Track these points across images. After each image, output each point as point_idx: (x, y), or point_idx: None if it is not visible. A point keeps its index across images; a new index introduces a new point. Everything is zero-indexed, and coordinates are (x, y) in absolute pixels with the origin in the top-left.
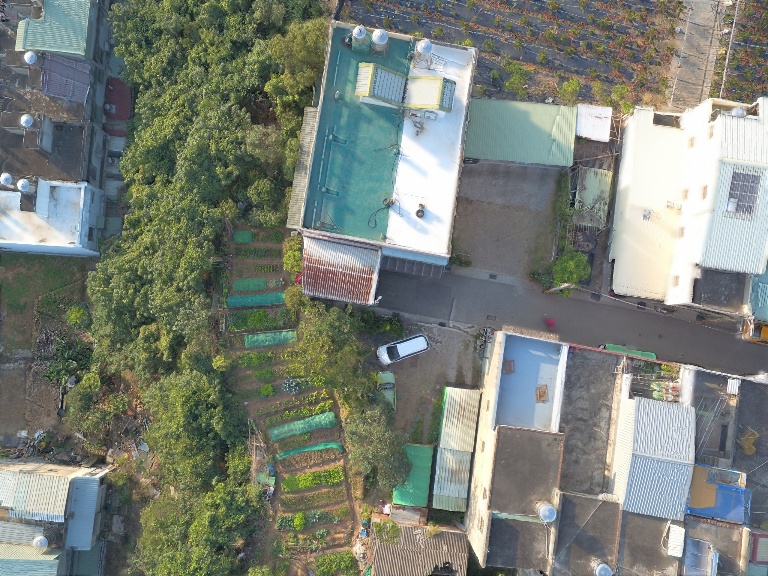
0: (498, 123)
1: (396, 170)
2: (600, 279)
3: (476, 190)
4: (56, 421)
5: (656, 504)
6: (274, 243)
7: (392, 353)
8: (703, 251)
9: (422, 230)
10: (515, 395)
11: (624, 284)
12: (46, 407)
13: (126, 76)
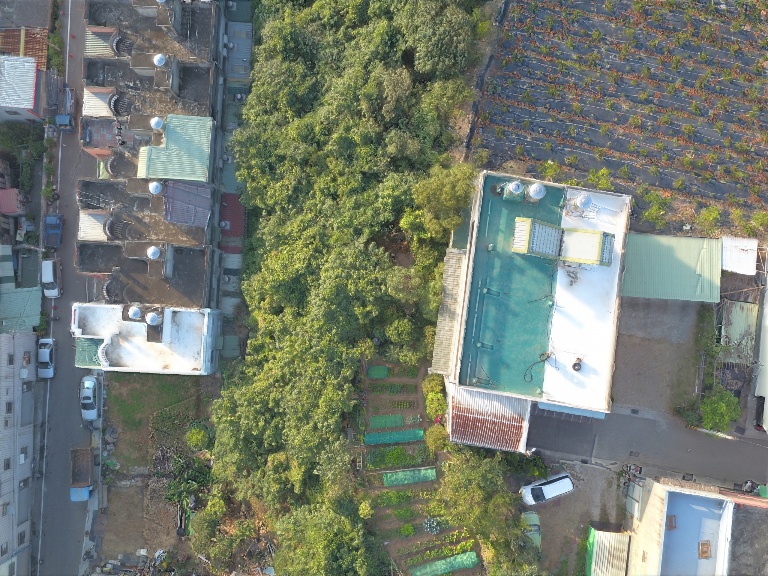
0: (642, 258)
1: (551, 322)
2: (745, 412)
3: None
4: (175, 540)
5: None
6: (409, 378)
7: (536, 494)
8: None
9: (579, 383)
10: (677, 551)
11: None
12: (164, 525)
13: (248, 201)
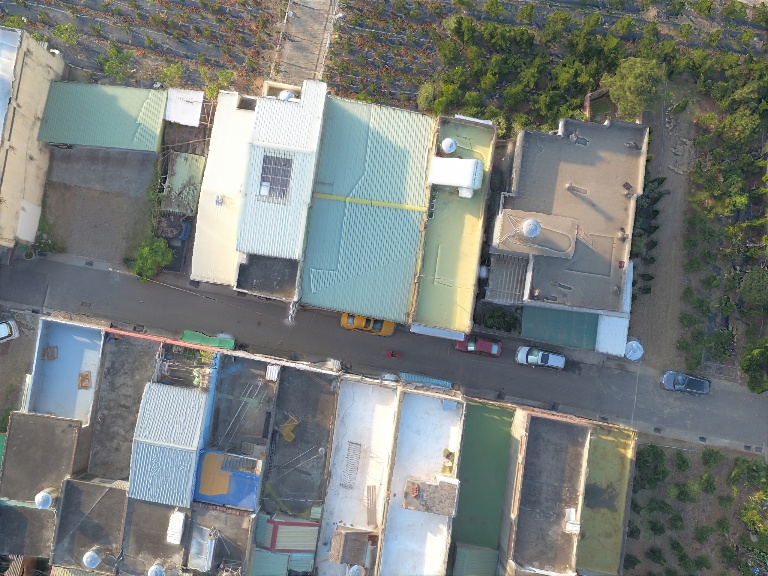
0: (84, 107)
1: None
2: None
3: (74, 175)
4: None
5: (161, 491)
6: None
7: None
8: (238, 235)
9: None
10: (57, 381)
11: (199, 270)
12: None
13: None
